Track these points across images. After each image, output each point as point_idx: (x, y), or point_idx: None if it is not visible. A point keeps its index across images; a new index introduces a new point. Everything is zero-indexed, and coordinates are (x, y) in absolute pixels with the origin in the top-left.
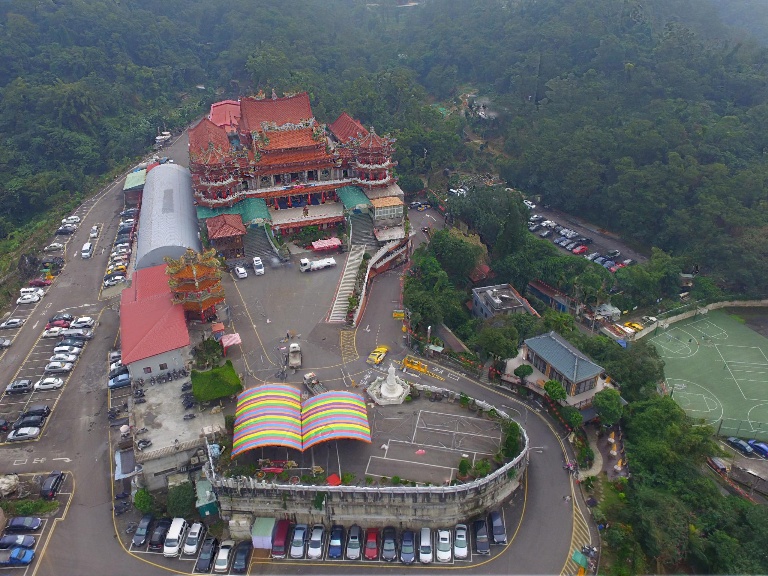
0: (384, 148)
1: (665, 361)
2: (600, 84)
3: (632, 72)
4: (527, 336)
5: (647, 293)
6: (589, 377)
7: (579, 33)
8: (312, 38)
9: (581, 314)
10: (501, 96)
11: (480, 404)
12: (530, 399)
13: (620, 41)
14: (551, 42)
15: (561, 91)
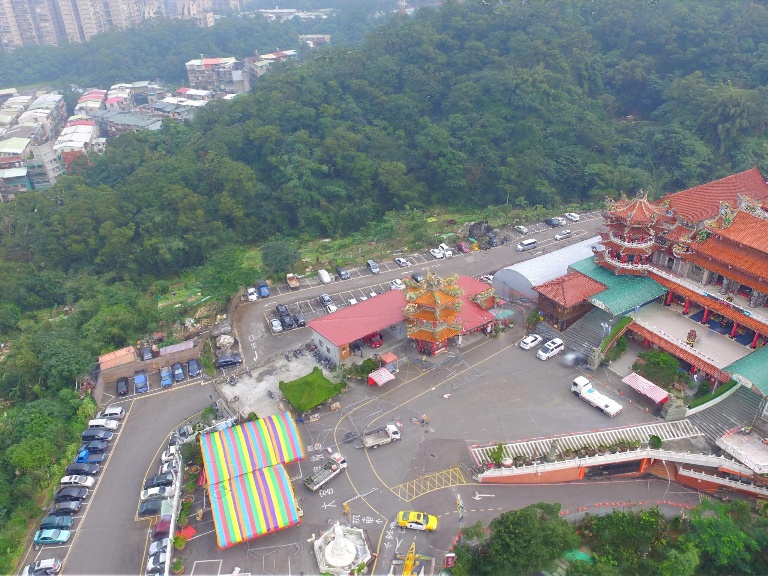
0: None
1: None
2: None
3: None
4: None
5: None
6: None
7: None
8: None
9: None
10: None
11: None
12: None
13: None
14: None
15: None
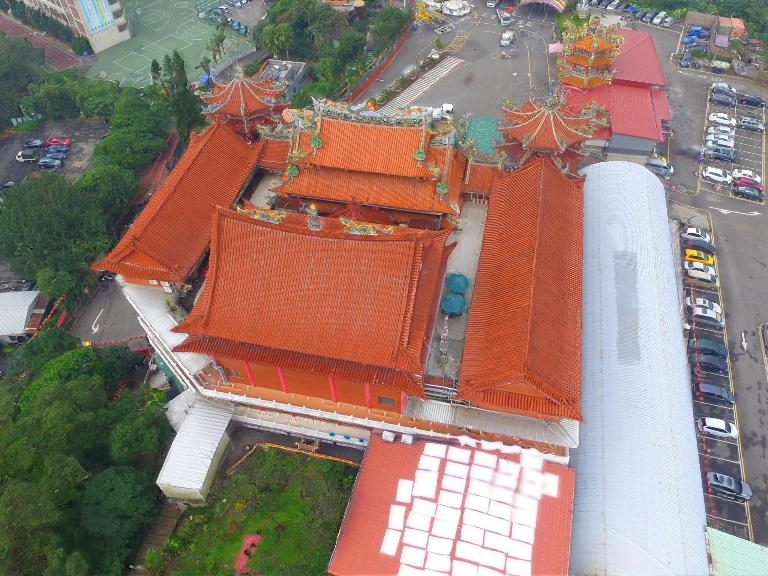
0: None
1: (192, 73)
2: None
3: None
4: None
5: None
6: None
7: None
8: None
9: None
10: None
11: None
12: None
13: None
14: None
15: None
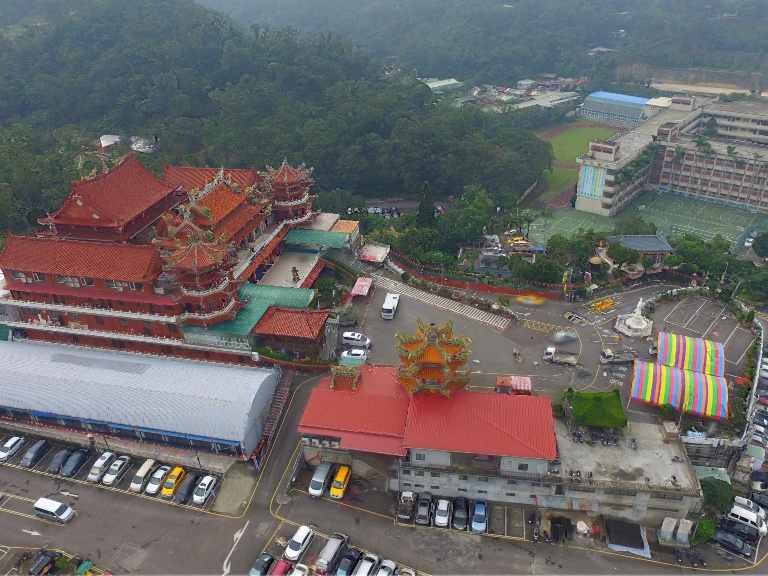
0: None
1: None
2: (266, 85)
3: (276, 70)
4: None
5: None
6: None
7: (184, 46)
8: None
9: None
10: (126, 128)
11: None
12: (651, 281)
13: None
14: (158, 60)
15: (237, 100)
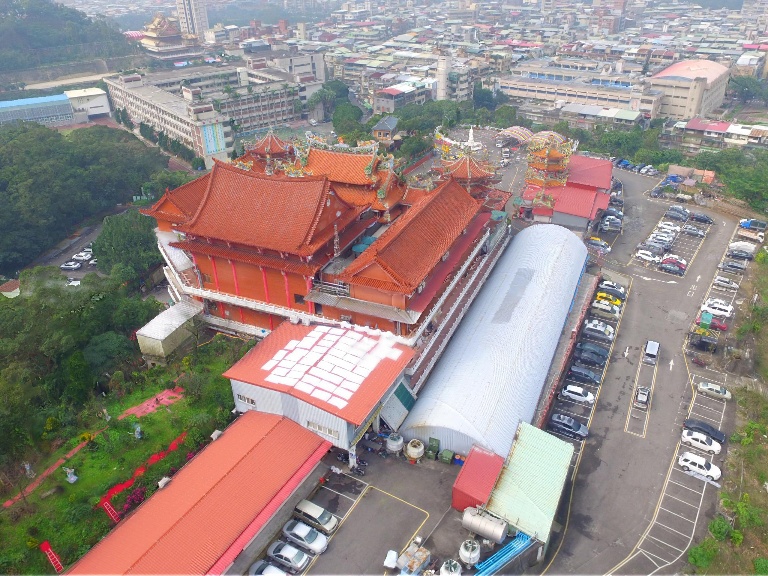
0: None
1: None
2: None
3: None
4: None
5: None
6: None
7: None
8: None
9: None
10: None
11: None
12: None
13: None
14: None
15: None
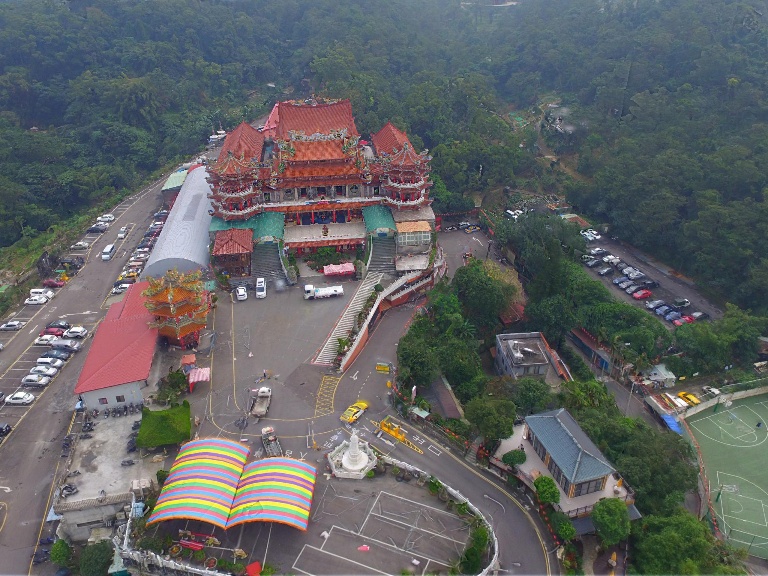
0: (417, 166)
1: (720, 448)
2: (695, 101)
3: (736, 89)
4: (535, 408)
5: (712, 358)
6: (594, 477)
7: (680, 41)
8: (390, 38)
9: (626, 375)
10: None
11: (453, 493)
12: (521, 491)
13: (727, 52)
14: (646, 50)
15: (648, 107)
